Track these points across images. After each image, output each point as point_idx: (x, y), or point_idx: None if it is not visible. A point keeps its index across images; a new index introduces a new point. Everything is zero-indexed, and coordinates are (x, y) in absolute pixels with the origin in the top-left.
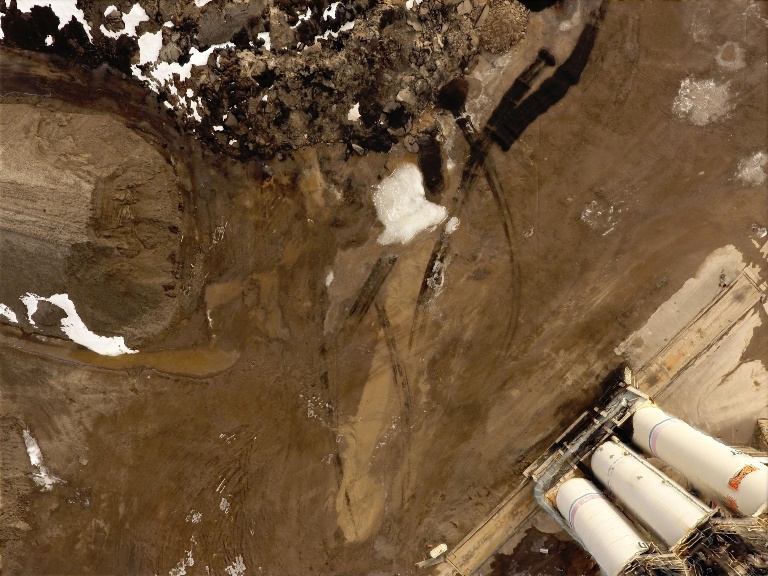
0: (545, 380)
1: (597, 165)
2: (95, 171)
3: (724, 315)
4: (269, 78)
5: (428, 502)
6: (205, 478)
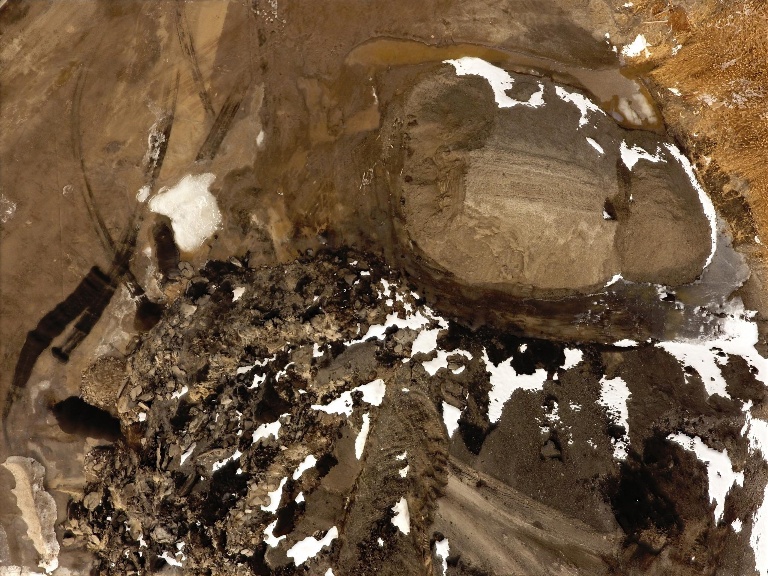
0: (41, 43)
1: (4, 256)
2: (467, 220)
3: None
4: (308, 313)
5: None
6: None
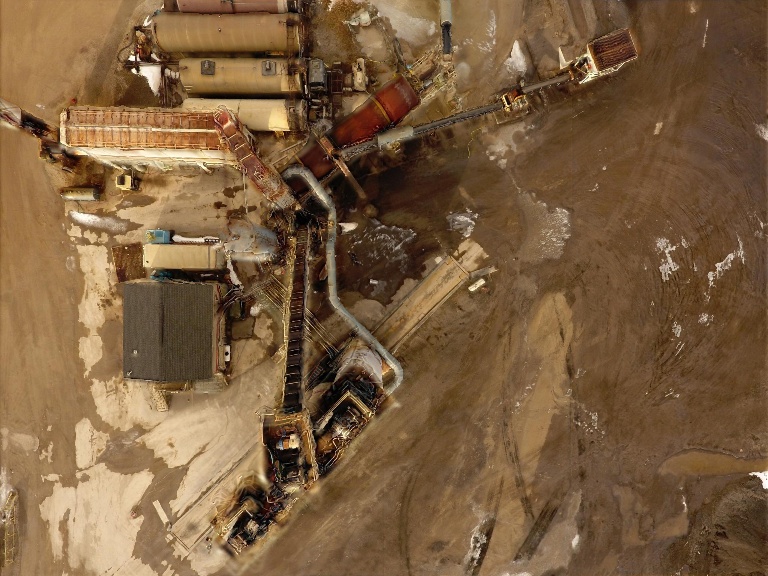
0: (375, 448)
1: None
2: None
3: (206, 511)
4: None
5: (486, 331)
6: (694, 356)
